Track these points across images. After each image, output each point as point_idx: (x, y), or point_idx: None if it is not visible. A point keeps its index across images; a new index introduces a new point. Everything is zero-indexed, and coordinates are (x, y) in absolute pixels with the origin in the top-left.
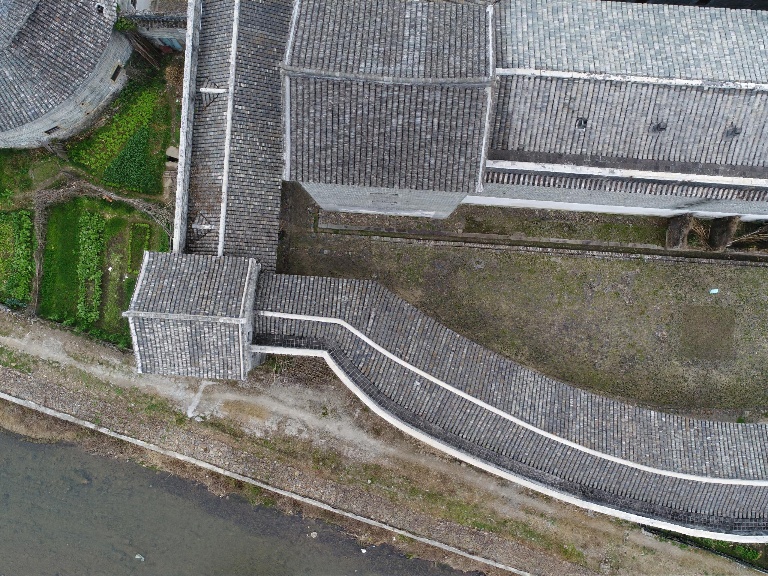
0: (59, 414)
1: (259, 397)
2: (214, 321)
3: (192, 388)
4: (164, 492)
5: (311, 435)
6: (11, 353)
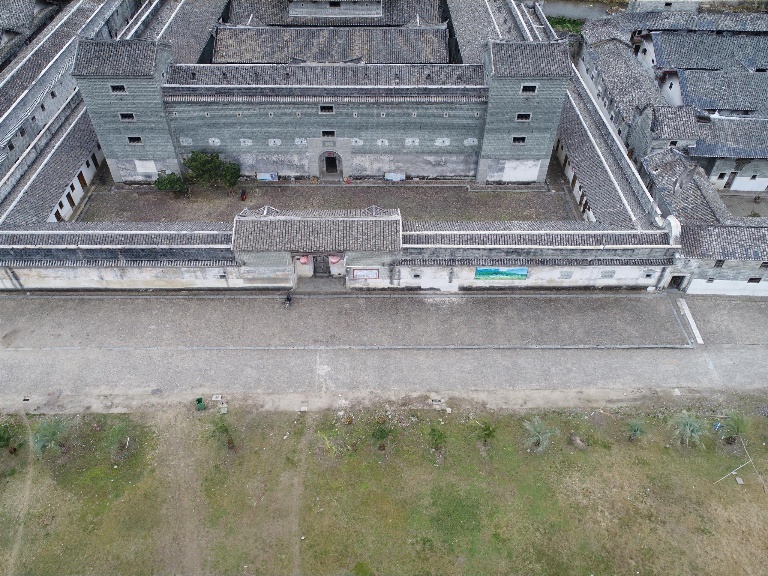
0: None
1: None
2: None
3: None
4: None
5: None
6: None
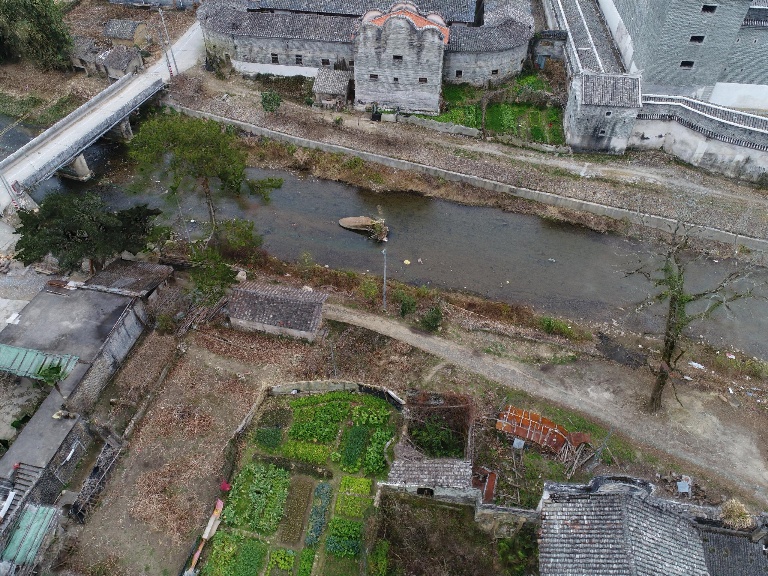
0: (492, 182)
1: (623, 169)
2: (626, 76)
3: (580, 165)
4: (560, 231)
5: (663, 184)
6: (466, 151)
